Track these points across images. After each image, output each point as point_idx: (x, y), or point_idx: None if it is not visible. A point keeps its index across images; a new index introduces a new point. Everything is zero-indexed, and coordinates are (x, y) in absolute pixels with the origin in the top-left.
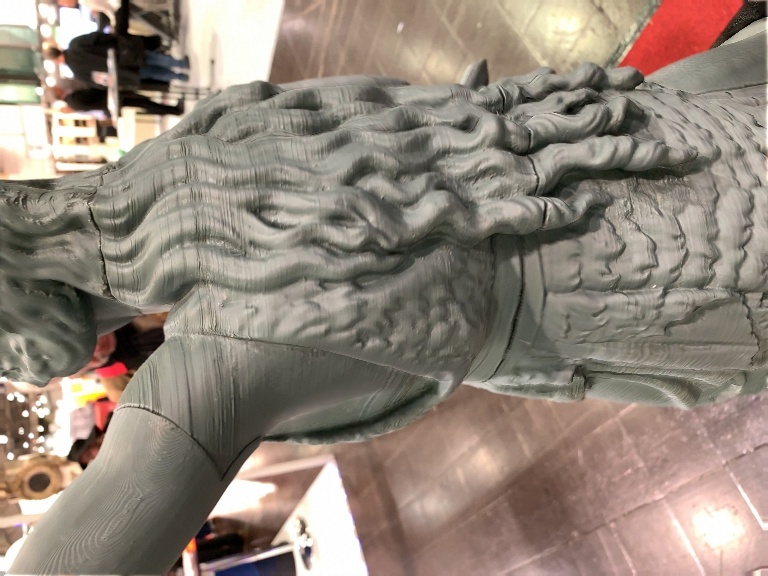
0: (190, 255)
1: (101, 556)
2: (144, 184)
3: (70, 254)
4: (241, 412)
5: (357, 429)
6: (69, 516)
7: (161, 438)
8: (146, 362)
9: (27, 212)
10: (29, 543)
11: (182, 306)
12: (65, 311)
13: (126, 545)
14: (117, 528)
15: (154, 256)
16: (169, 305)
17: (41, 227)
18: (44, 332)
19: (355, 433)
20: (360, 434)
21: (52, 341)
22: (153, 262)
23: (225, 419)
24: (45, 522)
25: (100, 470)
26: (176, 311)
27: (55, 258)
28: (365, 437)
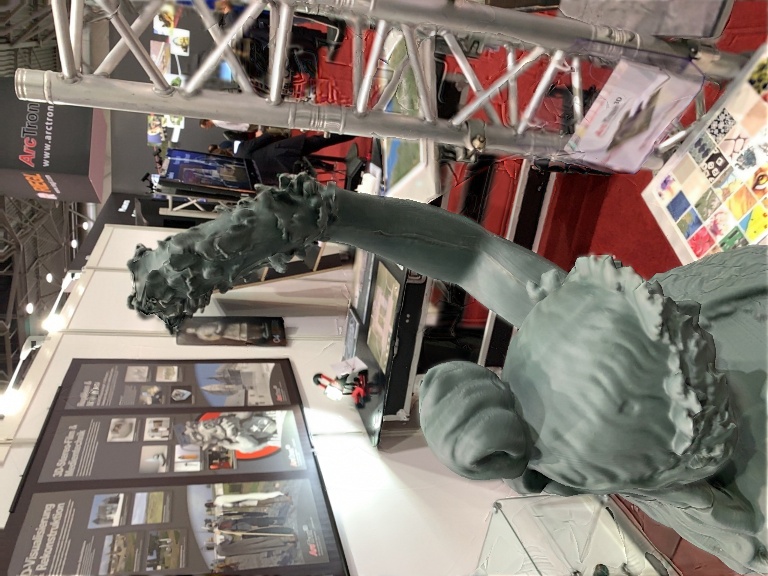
0: None
1: None
2: None
3: None
4: None
5: None
6: None
7: None
8: None
9: None
10: None
11: None
12: None
13: None
14: None
15: None
16: None
17: None
18: None
19: None
20: None
21: None
22: None
23: None
24: None
25: None
26: None
27: None
28: None
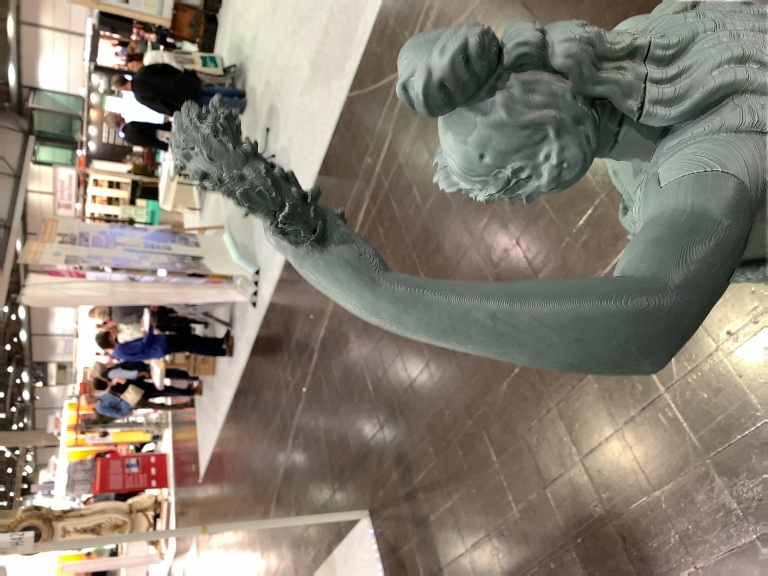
0: (740, 70)
1: (712, 256)
2: (686, 30)
3: (624, 76)
4: (767, 188)
5: (761, 263)
6: (678, 232)
7: (734, 188)
8: (677, 157)
9: (607, 40)
10: (651, 247)
11: (711, 116)
12: (593, 127)
13: (724, 253)
14: (718, 240)
15: (704, 74)
16: (646, 141)
17: (613, 52)
18: (576, 141)
19: (760, 266)
20: (763, 267)
21: (579, 149)
22: (702, 78)
23: (762, 188)
24: (657, 236)
25: (685, 209)
26: (701, 122)
27: (614, 77)
28: (765, 272)
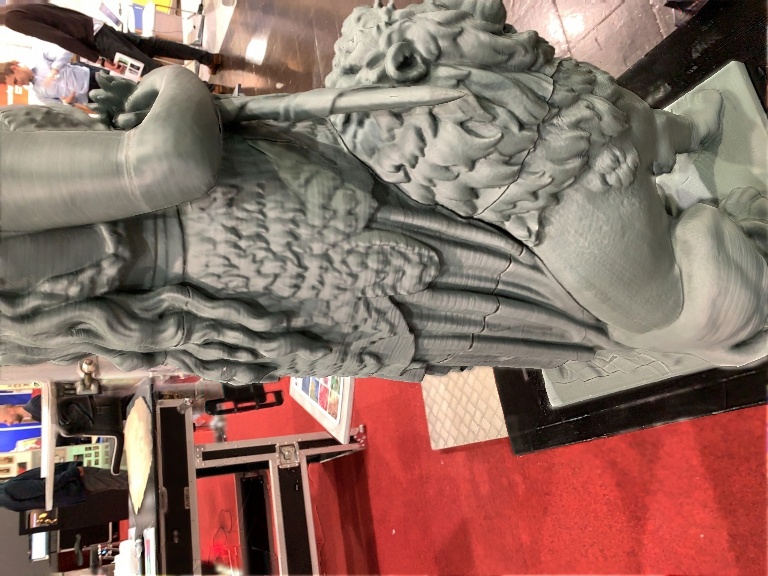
0: None
1: None
2: None
3: None
4: None
5: None
6: None
7: None
8: None
9: None
10: None
11: None
12: None
13: None
14: None
15: None
16: None
17: None
18: None
19: None
20: None
21: None
22: None
23: None
24: None
25: None
26: None
27: None
28: None
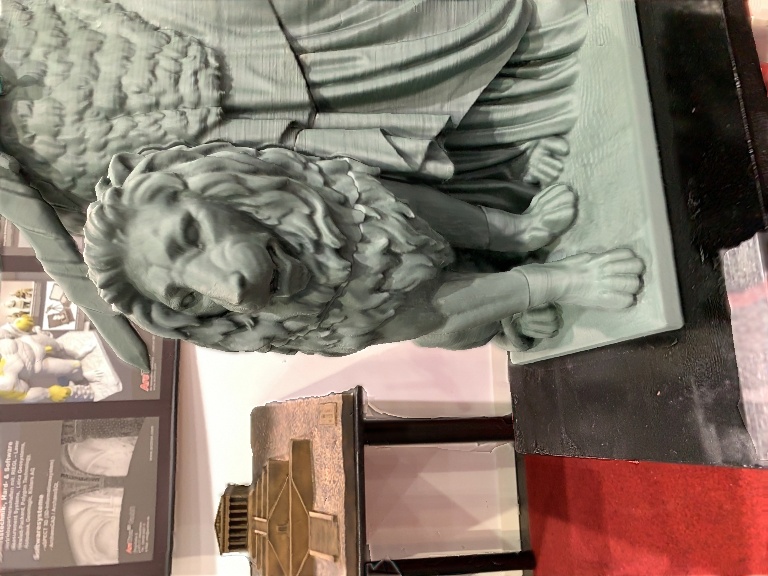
0: None
1: None
2: None
3: None
4: None
5: None
6: None
7: None
8: None
9: None
10: None
11: None
12: None
13: None
14: None
15: None
16: None
17: None
18: None
19: None
20: None
21: None
22: None
23: None
24: None
25: None
26: None
27: None
28: None
